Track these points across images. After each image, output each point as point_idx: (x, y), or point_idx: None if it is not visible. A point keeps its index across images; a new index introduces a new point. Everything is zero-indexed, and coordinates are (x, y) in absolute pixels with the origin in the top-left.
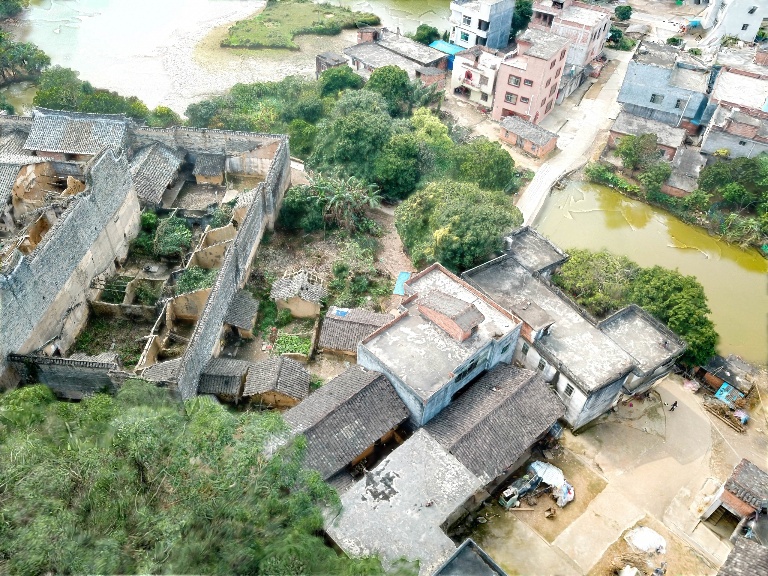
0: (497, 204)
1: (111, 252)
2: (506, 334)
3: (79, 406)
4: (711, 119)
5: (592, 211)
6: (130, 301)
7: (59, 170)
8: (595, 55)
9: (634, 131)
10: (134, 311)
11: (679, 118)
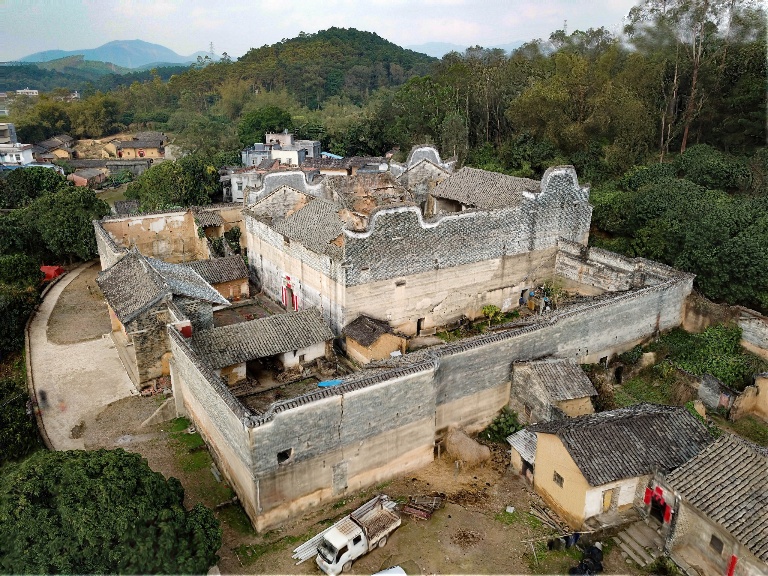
0: None
1: None
2: None
3: None
4: None
5: None
6: None
7: None
8: None
9: None
10: None
11: None
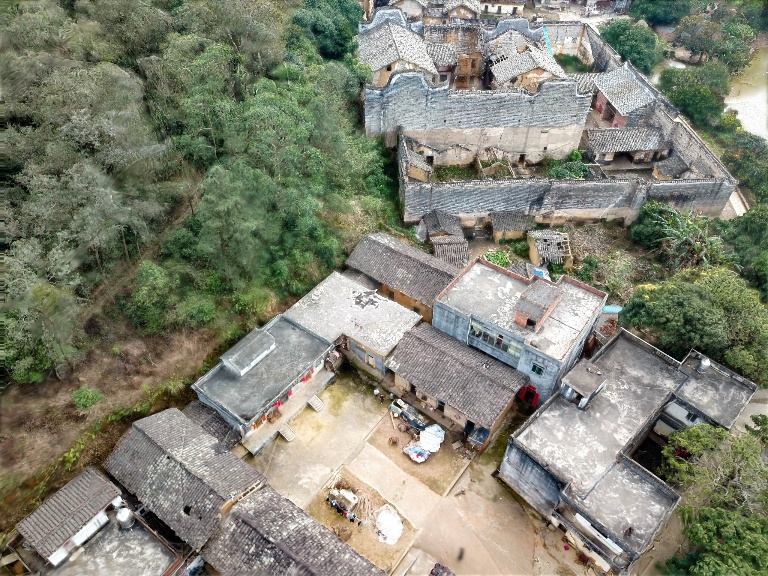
0: (759, 342)
1: (522, 147)
2: (537, 349)
3: (298, 86)
4: None
5: None
6: None
7: None
8: None
9: None
10: None
11: None
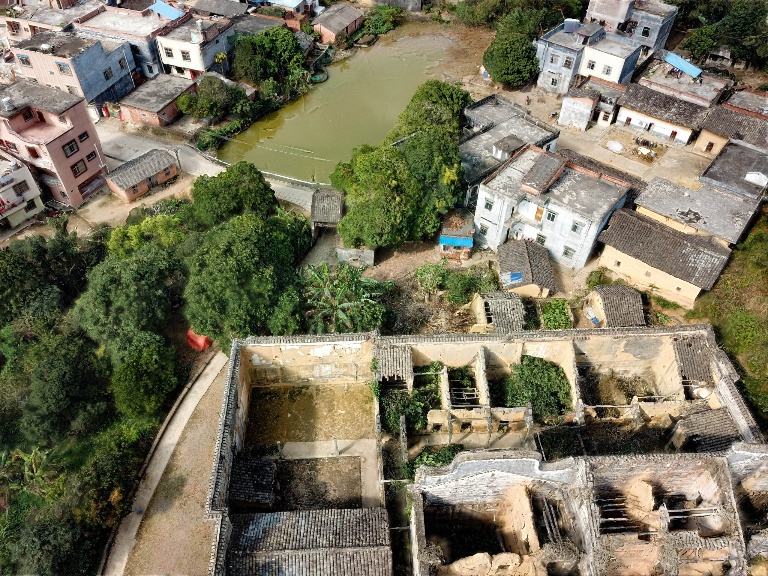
0: None
1: None
2: None
3: None
4: (175, 47)
5: None
6: None
7: None
8: None
9: (160, 100)
10: None
11: (129, 75)
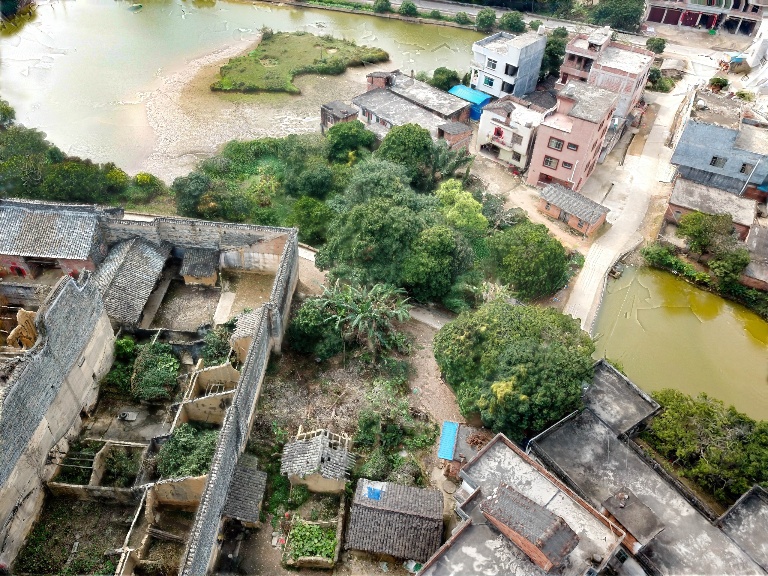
0: (563, 332)
1: (75, 405)
2: (607, 558)
3: None
4: None
5: (657, 308)
6: (99, 477)
7: (9, 293)
8: (636, 102)
9: (697, 204)
10: (104, 494)
11: (744, 184)
